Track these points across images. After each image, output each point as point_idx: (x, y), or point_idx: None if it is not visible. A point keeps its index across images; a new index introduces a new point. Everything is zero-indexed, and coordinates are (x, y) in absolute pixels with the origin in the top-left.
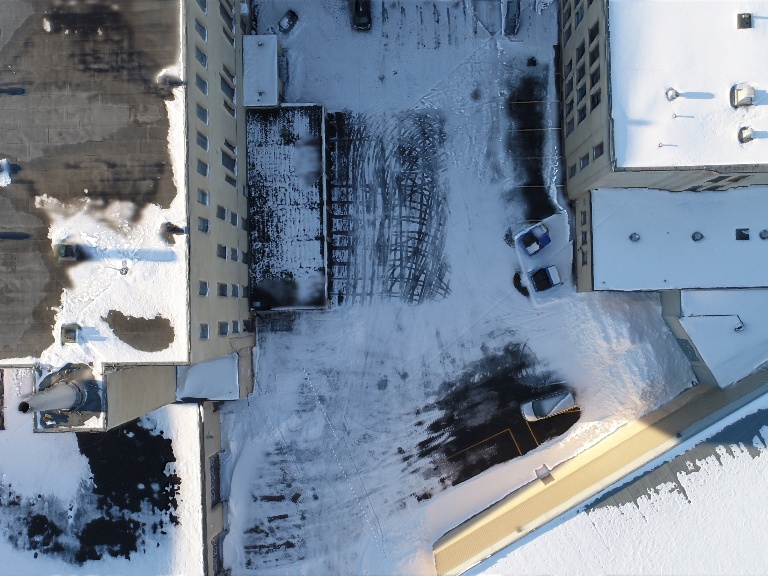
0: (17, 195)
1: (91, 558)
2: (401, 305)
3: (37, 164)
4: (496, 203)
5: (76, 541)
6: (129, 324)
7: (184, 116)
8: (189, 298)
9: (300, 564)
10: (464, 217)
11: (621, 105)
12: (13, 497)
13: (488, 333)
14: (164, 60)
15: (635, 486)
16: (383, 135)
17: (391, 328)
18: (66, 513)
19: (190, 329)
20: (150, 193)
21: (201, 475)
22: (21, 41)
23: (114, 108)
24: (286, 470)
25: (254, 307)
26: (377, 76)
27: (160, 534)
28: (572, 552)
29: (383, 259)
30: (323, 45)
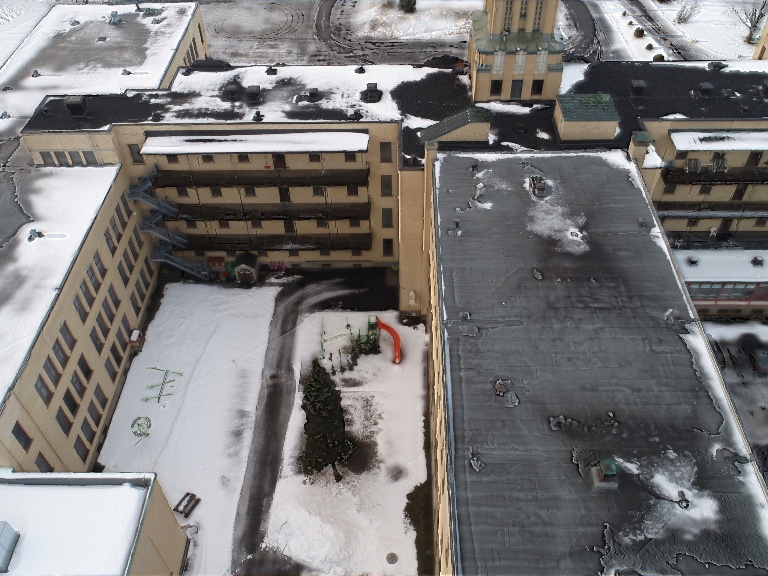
0: (528, 416)
1: None
2: None
3: (548, 386)
4: None
5: None
6: (710, 574)
7: (708, 346)
8: None
9: None
10: None
11: None
12: None
13: None
14: (668, 302)
15: None
16: None
17: None
18: None
19: None
20: (690, 418)
21: None
22: (514, 285)
23: (625, 339)
24: None
25: None
26: (745, 410)
27: None
28: None
29: None
30: None
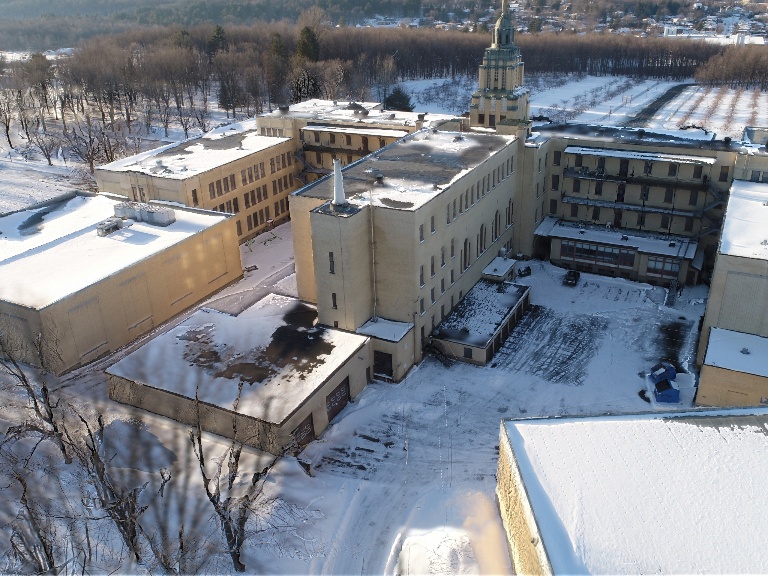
0: None
1: (226, 377)
2: (539, 380)
3: None
4: (636, 359)
5: (225, 367)
6: (392, 201)
7: None
8: (431, 200)
9: (362, 480)
10: (608, 358)
11: (728, 240)
12: (209, 340)
13: (607, 410)
14: None
15: (718, 419)
16: (563, 318)
17: (525, 387)
18: (233, 355)
19: (424, 205)
20: None
21: (342, 363)
22: None
23: None
24: (393, 428)
25: (433, 336)
26: None
27: (285, 380)
28: (642, 438)
29: (537, 359)
30: (541, 285)
